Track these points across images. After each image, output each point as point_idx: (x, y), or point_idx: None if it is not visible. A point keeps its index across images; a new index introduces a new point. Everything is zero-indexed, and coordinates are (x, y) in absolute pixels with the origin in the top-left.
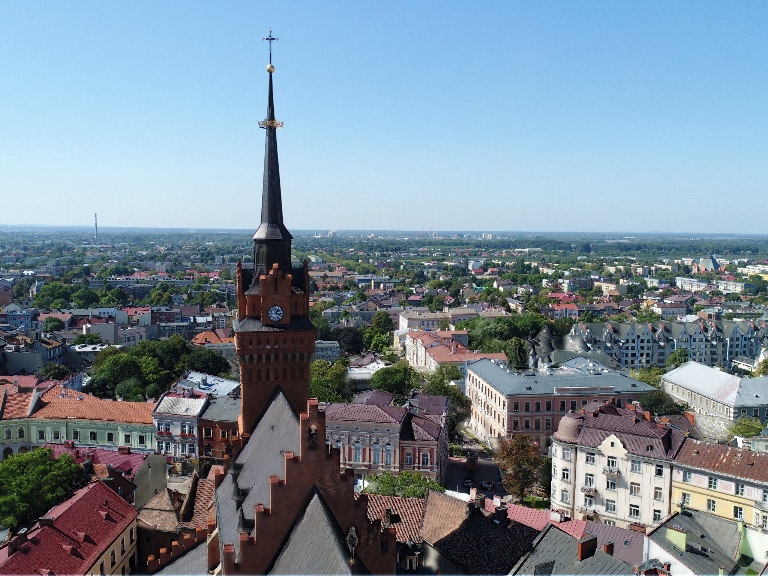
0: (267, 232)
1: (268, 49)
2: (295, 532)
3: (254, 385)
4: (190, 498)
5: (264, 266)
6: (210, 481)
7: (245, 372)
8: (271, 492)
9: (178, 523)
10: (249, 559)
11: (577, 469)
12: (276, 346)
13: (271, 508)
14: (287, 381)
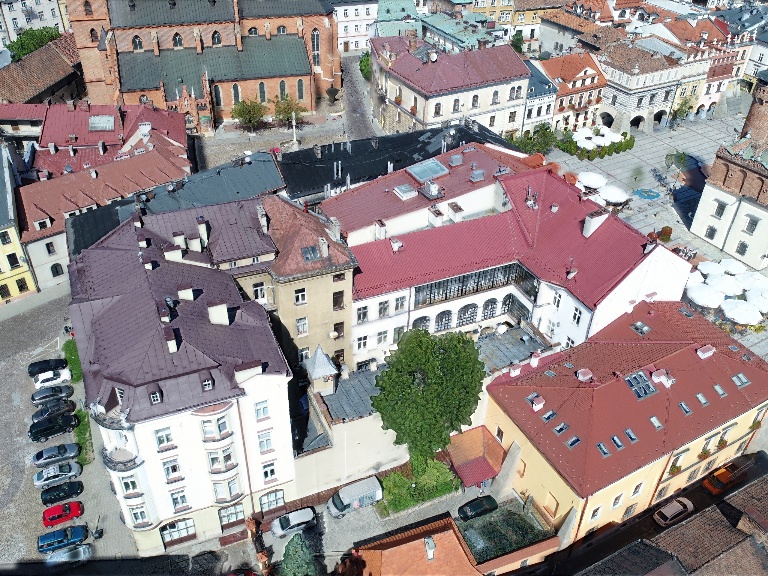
0: None
1: None
2: None
3: None
4: None
5: None
6: None
7: None
8: None
9: None
10: None
11: (6, 19)
12: None
13: None
14: None
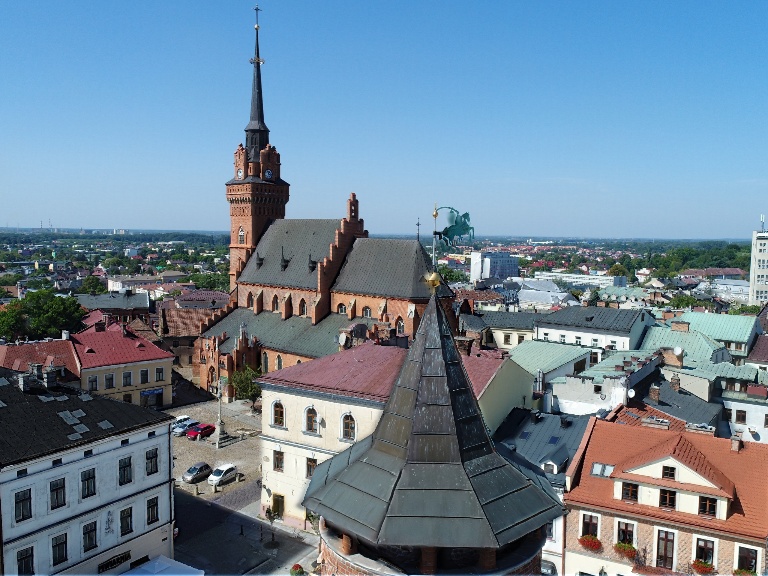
0: (259, 126)
1: (255, 15)
2: (351, 255)
3: (257, 217)
4: (163, 320)
5: (257, 146)
6: (174, 309)
7: (253, 208)
8: (338, 237)
9: (161, 335)
10: (330, 270)
11: None
12: (270, 193)
13: (338, 245)
14: (273, 216)
